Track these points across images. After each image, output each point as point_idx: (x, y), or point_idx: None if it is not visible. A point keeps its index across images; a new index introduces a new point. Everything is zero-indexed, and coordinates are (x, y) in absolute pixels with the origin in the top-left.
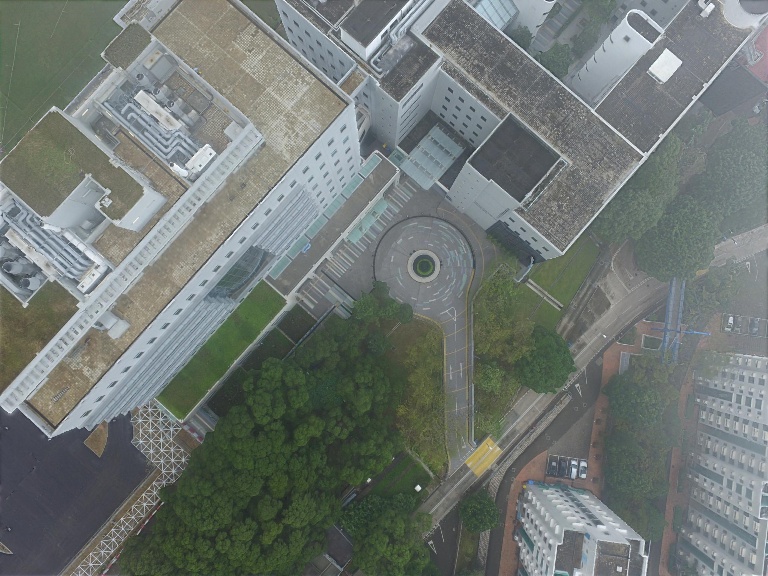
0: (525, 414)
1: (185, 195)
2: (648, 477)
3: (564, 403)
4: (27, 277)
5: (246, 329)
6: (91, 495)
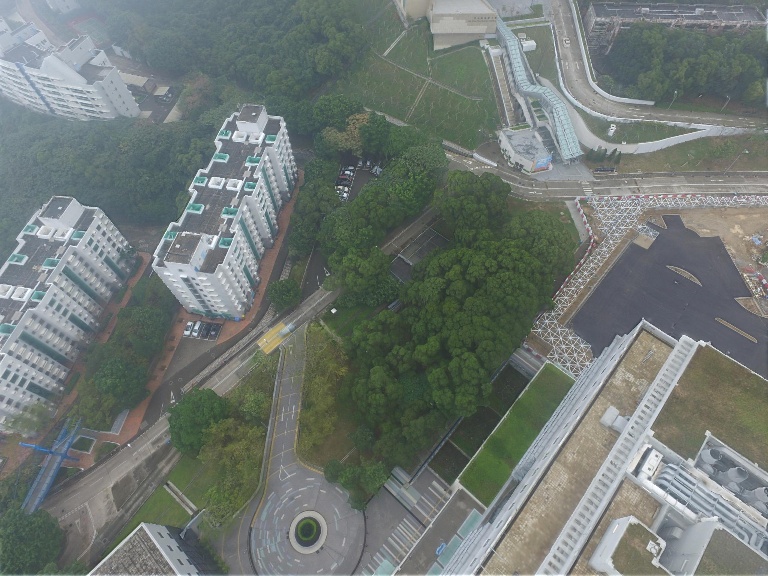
0: (229, 375)
1: (567, 567)
2: (133, 319)
3: (190, 384)
4: (722, 469)
5: (499, 450)
6: (616, 306)
